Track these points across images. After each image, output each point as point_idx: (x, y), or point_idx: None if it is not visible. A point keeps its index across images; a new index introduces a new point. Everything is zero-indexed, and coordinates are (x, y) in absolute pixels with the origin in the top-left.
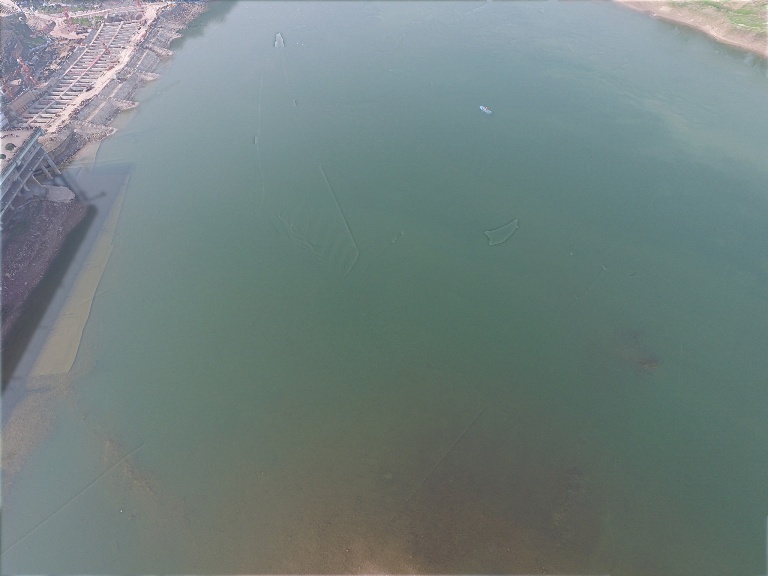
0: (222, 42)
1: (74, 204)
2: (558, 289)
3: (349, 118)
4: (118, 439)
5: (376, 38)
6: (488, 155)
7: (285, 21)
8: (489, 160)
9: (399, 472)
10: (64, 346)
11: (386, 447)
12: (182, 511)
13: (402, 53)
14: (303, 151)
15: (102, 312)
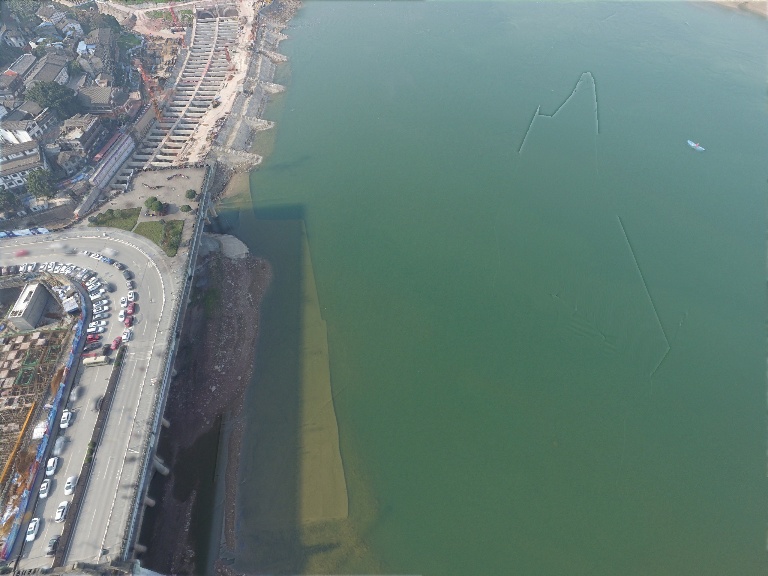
0: (339, 47)
1: (252, 260)
2: None
3: None
4: None
5: (517, 49)
6: (737, 208)
7: (402, 24)
8: (740, 215)
9: None
10: (325, 475)
11: None
12: None
13: (559, 69)
14: (601, 220)
15: (351, 421)
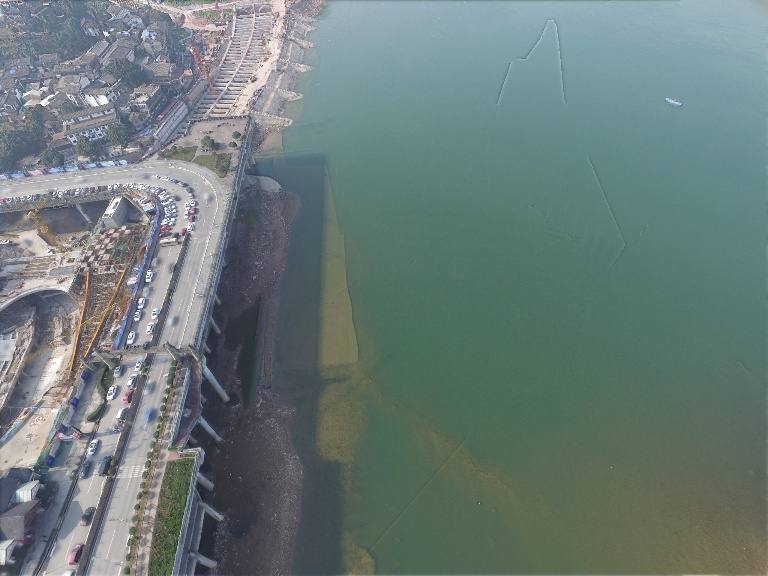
0: (359, 35)
1: (284, 194)
2: None
3: None
4: (442, 430)
5: (518, 31)
6: (703, 148)
7: (415, 14)
8: (705, 153)
9: (760, 469)
10: (341, 335)
11: (732, 443)
12: (545, 504)
13: None
14: (566, 140)
15: (362, 302)
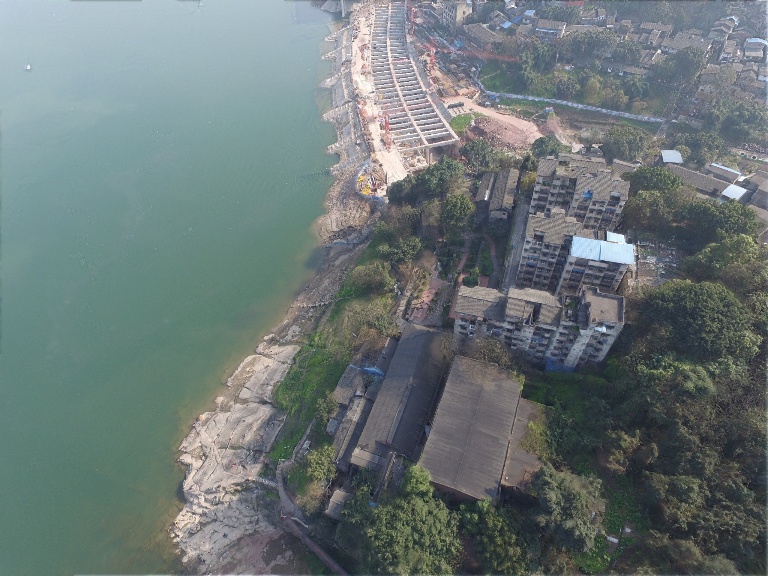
0: (263, 141)
1: (318, 6)
2: (88, 4)
3: (138, 56)
4: None
5: None
6: (64, 34)
7: (165, 187)
8: (66, 34)
9: None
10: None
11: None
12: None
13: None
14: None
15: None
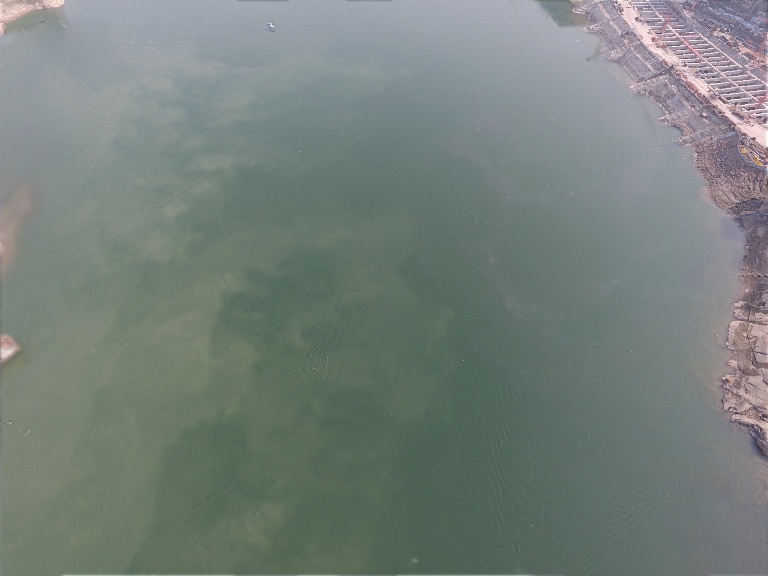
0: (581, 110)
1: None
2: None
3: (382, 19)
4: None
5: (359, 112)
6: None
7: (511, 151)
8: None
9: None
10: None
11: None
12: None
13: (329, 80)
14: None
15: None
